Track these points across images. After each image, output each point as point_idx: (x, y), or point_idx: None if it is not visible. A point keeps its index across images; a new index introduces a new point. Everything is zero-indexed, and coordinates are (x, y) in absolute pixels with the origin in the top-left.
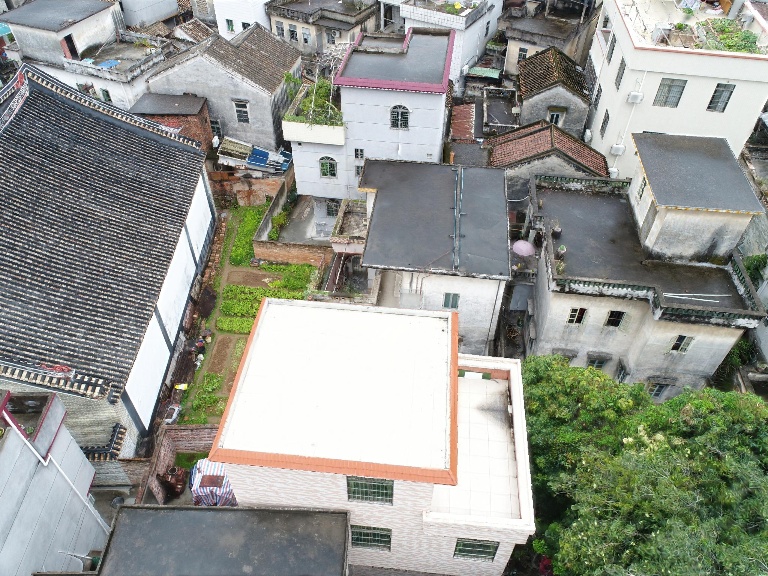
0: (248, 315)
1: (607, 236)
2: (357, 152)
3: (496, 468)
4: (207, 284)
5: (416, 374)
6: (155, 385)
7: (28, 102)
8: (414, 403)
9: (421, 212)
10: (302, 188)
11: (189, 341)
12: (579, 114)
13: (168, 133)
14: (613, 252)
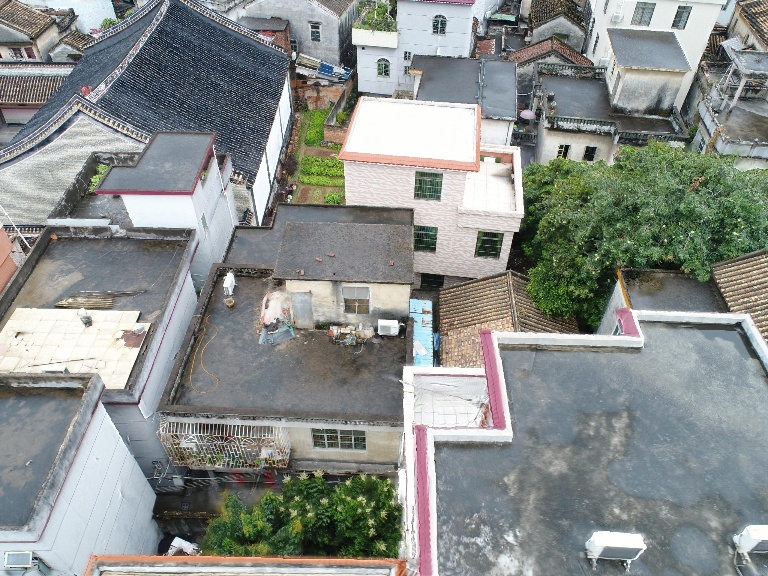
0: (322, 175)
1: (587, 101)
2: (406, 54)
3: (502, 199)
4: (291, 154)
5: (456, 130)
6: (264, 203)
7: (169, 10)
8: (455, 140)
9: (455, 84)
10: (362, 86)
11: (281, 187)
12: (577, 40)
13: (264, 41)
14: (590, 109)
